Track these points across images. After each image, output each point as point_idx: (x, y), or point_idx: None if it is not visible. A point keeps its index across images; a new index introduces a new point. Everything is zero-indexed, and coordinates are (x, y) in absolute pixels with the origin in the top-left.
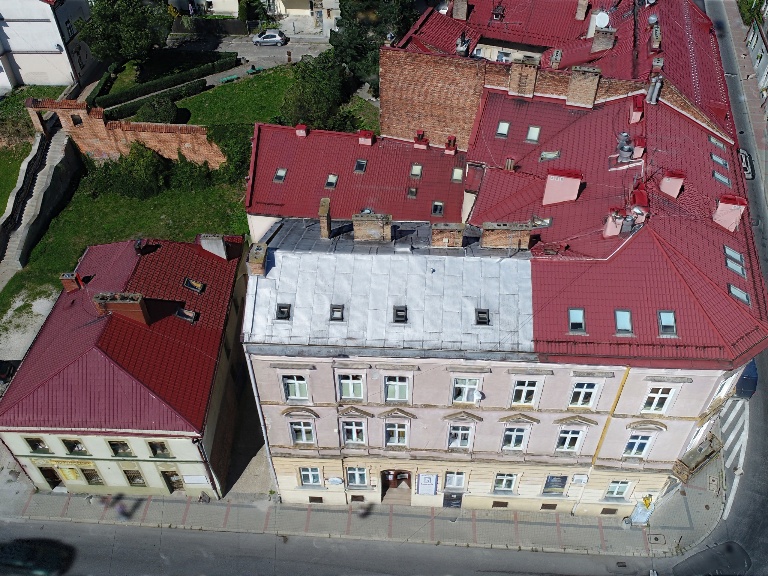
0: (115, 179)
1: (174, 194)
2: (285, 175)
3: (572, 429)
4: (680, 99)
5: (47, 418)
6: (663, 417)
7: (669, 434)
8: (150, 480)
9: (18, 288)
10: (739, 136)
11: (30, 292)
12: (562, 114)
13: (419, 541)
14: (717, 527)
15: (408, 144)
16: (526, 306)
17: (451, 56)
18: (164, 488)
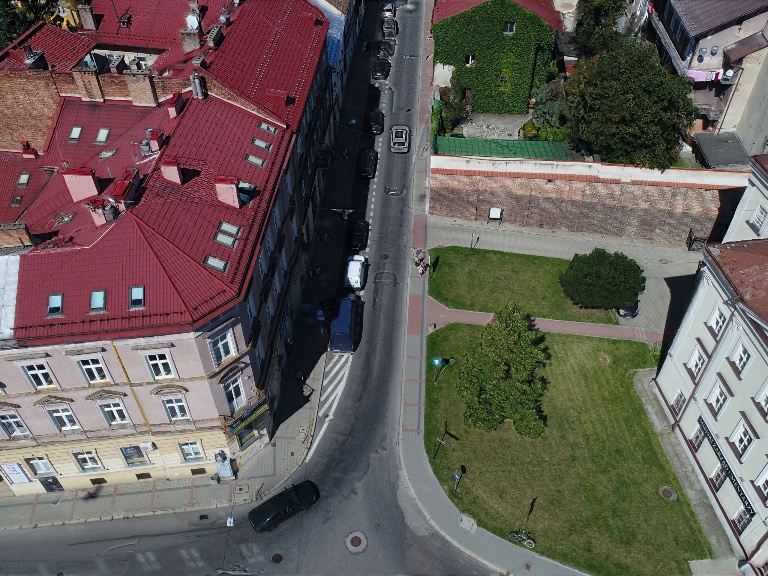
0: None
1: None
2: None
3: (109, 403)
4: (225, 92)
5: None
6: (175, 380)
7: (194, 394)
8: None
9: None
10: (405, 114)
11: None
12: (130, 115)
13: (17, 527)
14: (298, 470)
15: (19, 155)
16: (11, 298)
17: (19, 69)
18: None
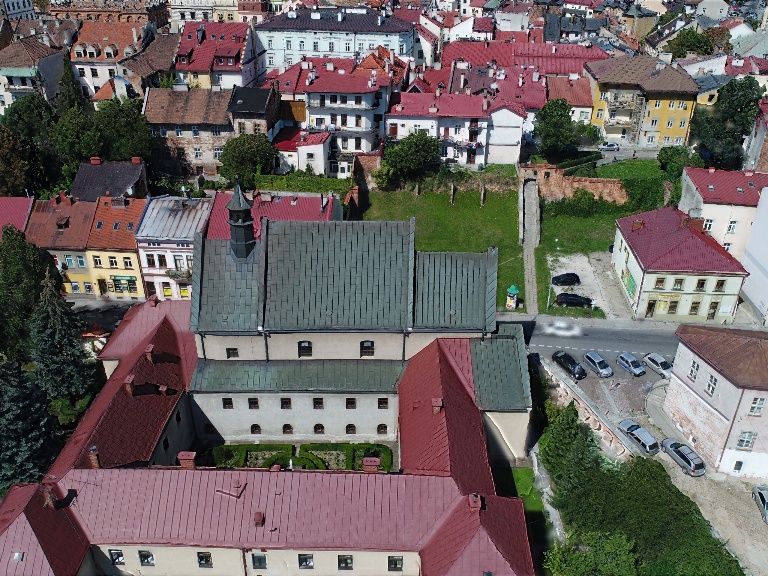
0: (567, 207)
1: (602, 216)
2: (714, 188)
3: None
4: None
5: (674, 266)
6: None
7: None
8: (702, 310)
9: (544, 253)
10: None
11: (552, 255)
12: None
13: None
14: None
15: None
16: None
17: None
18: (706, 316)
